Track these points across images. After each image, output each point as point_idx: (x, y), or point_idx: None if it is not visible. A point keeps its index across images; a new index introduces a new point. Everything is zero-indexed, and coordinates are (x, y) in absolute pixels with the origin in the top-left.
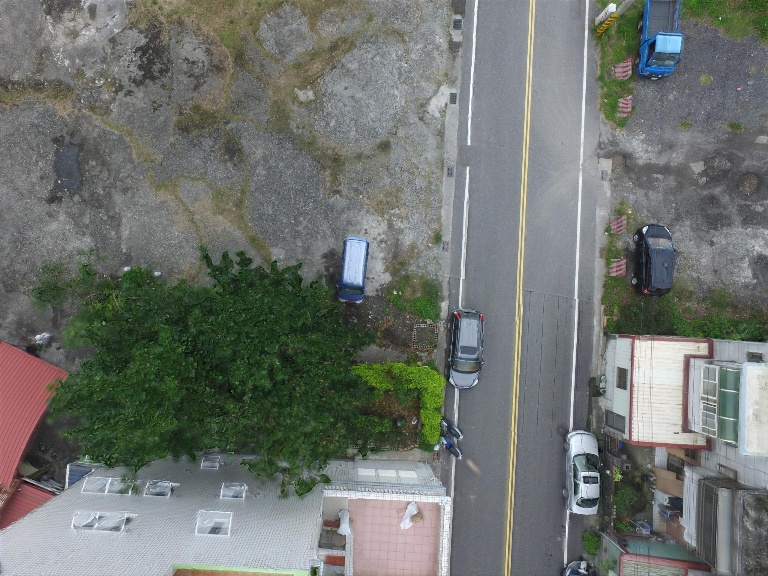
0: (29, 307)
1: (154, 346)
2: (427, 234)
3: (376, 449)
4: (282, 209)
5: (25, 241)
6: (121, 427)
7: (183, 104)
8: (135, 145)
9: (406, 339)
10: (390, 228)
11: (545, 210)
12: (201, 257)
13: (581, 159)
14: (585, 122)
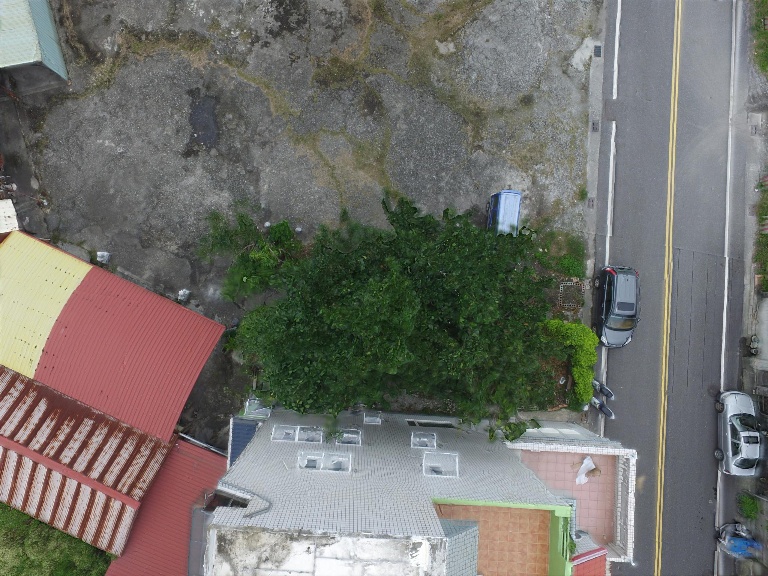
0: (167, 263)
1: (357, 287)
2: (572, 190)
3: (524, 409)
4: (424, 164)
5: (162, 196)
6: (360, 361)
7: (321, 56)
8: (273, 98)
9: (553, 297)
10: (534, 184)
11: (694, 166)
12: (341, 213)
13: (730, 114)
14: (734, 76)
